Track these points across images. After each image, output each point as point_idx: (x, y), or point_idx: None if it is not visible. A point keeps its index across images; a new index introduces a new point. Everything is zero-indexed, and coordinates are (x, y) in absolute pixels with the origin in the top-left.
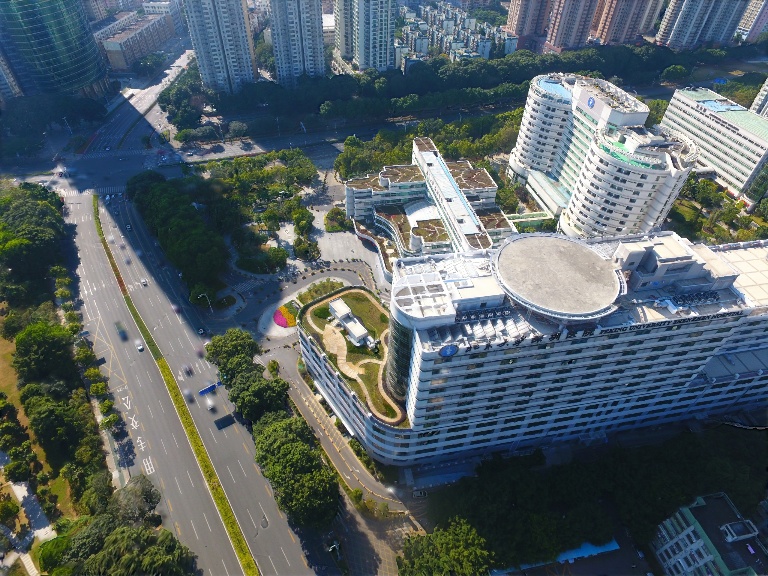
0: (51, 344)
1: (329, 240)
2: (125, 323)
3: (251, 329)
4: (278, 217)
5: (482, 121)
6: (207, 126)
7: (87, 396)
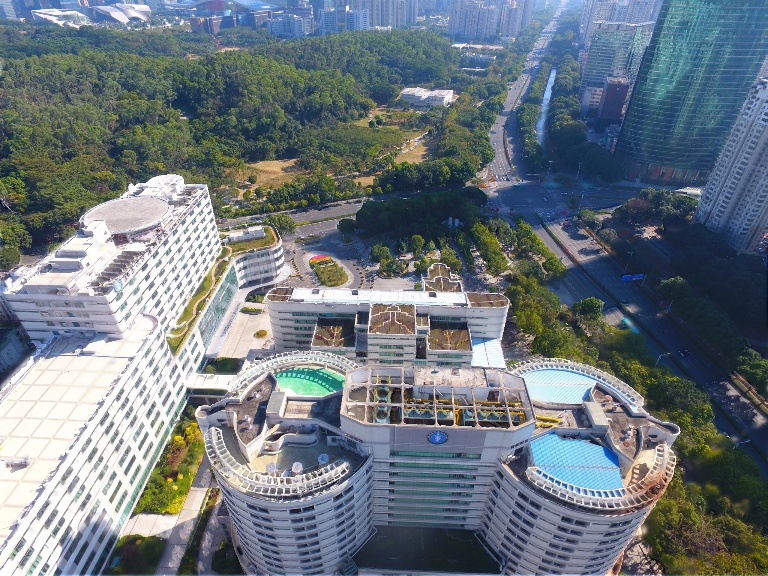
0: (318, 185)
1: (403, 284)
2: (346, 213)
3: (317, 248)
4: (416, 244)
5: (741, 481)
6: (599, 219)
7: (298, 208)
